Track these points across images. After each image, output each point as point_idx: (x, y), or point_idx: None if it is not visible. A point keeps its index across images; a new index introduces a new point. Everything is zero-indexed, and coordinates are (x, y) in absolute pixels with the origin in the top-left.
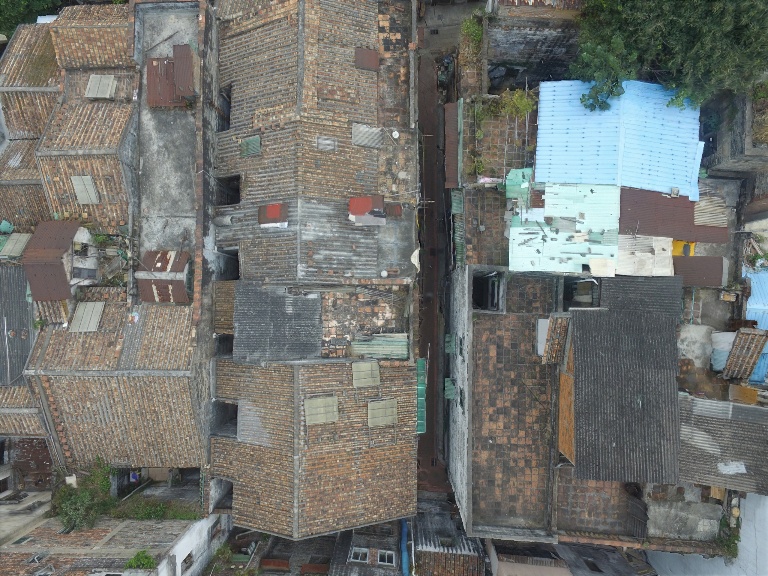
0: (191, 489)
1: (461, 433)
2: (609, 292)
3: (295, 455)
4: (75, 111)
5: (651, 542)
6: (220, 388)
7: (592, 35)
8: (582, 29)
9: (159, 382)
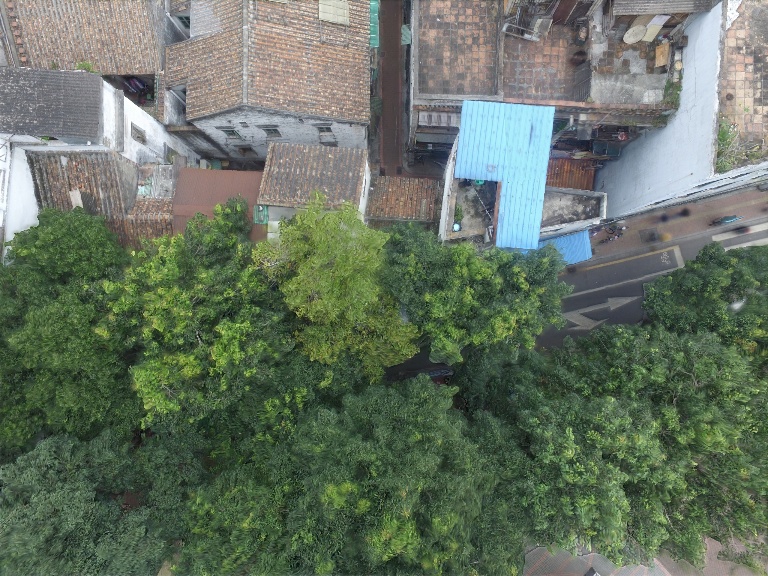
0: None
1: None
2: None
3: (244, 25)
4: None
5: (597, 115)
6: None
7: None
8: None
9: None
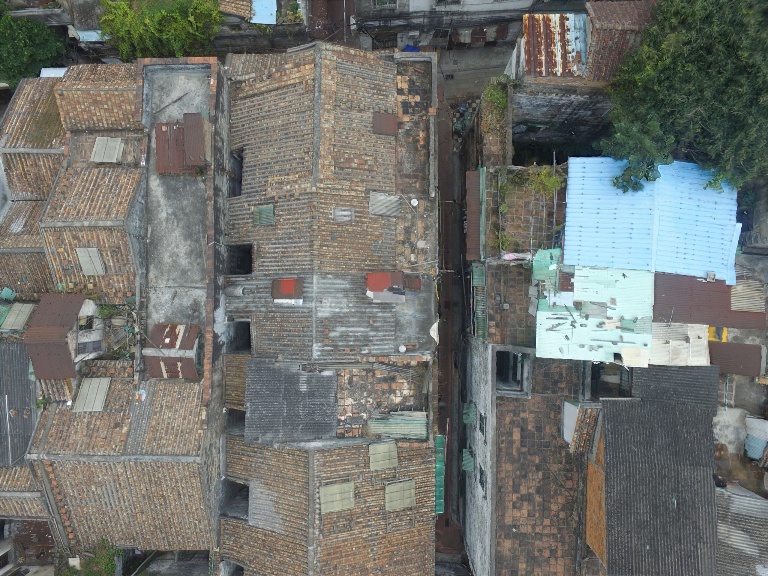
0: (199, 563)
1: (482, 515)
2: (641, 380)
3: (310, 546)
4: (80, 177)
5: None
6: (230, 466)
7: (625, 111)
8: (613, 102)
9: (167, 467)
